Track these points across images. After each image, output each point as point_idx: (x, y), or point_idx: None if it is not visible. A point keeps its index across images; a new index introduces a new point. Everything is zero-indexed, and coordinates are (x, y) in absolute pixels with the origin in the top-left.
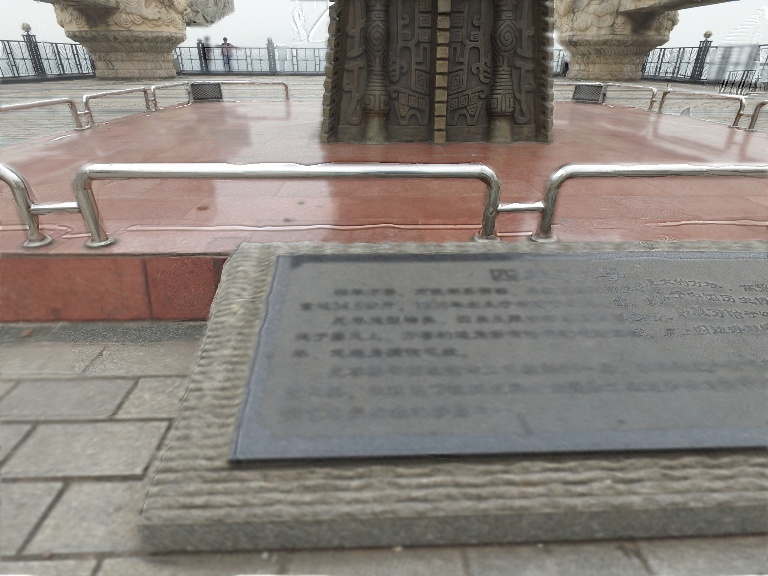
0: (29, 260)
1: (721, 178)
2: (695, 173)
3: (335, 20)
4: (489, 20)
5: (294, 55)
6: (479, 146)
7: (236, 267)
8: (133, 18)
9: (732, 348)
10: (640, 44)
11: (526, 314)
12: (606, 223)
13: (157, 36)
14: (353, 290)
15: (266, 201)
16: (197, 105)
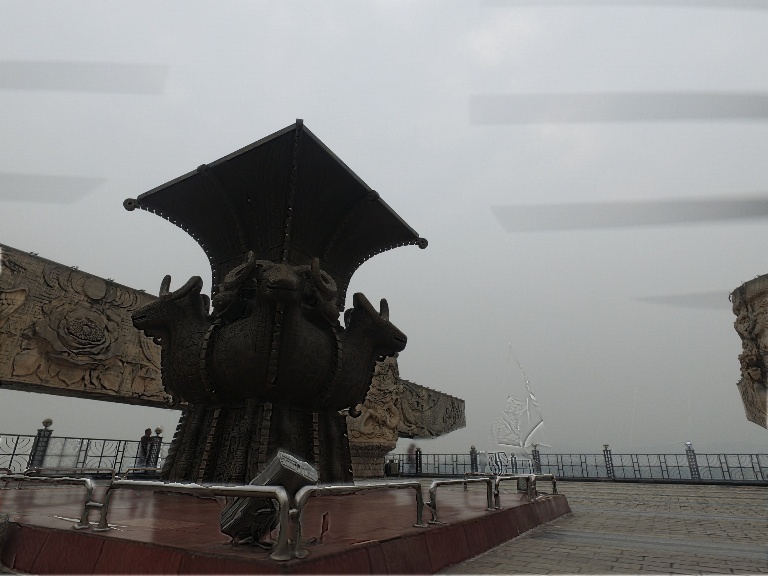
0: None
1: None
2: None
3: None
4: None
5: None
6: None
7: None
8: (354, 433)
9: None
10: None
11: None
12: (33, 514)
13: (369, 445)
14: None
15: None
16: None
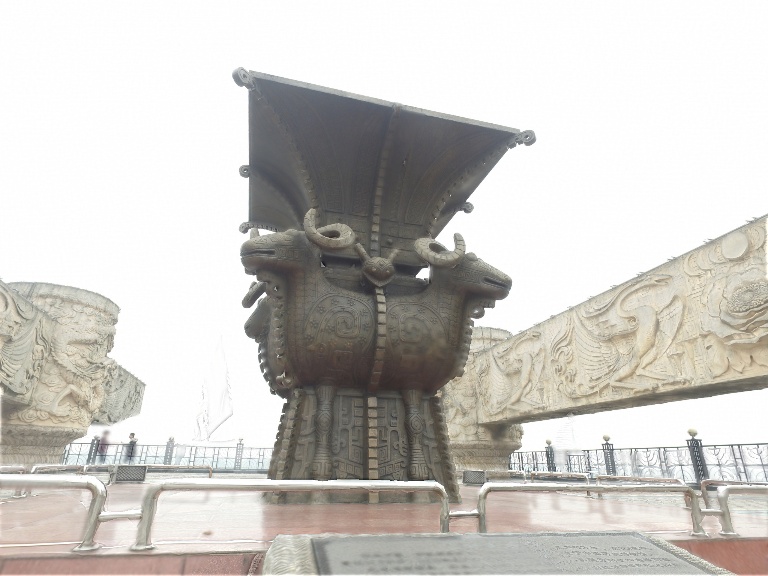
0: (82, 561)
1: (588, 517)
2: (561, 489)
3: (295, 409)
4: (402, 413)
5: (193, 453)
6: (406, 505)
7: (280, 548)
8: (40, 414)
9: (616, 575)
10: (501, 448)
11: (491, 564)
12: None
13: (57, 431)
14: (375, 552)
15: (258, 530)
16: (120, 485)
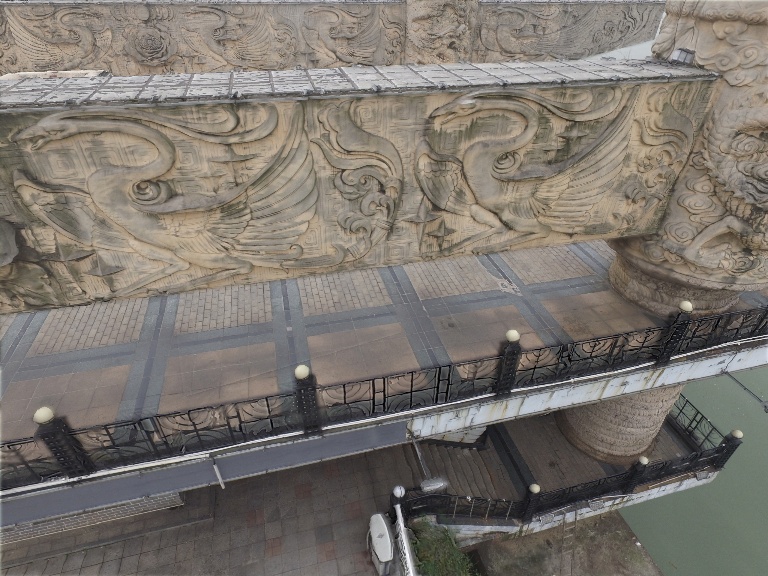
0: None
1: None
2: None
3: None
4: None
5: None
6: None
7: None
8: None
9: None
10: None
11: None
12: None
13: None
14: None
15: None
16: None
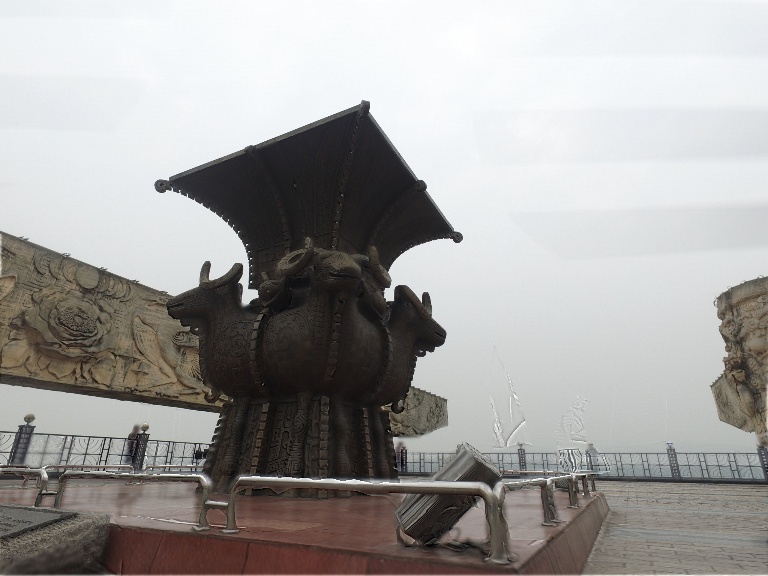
0: None
1: (299, 514)
2: (106, 476)
3: None
4: None
5: None
6: None
7: None
8: None
9: None
10: None
11: None
12: None
13: None
14: None
15: None
16: None
